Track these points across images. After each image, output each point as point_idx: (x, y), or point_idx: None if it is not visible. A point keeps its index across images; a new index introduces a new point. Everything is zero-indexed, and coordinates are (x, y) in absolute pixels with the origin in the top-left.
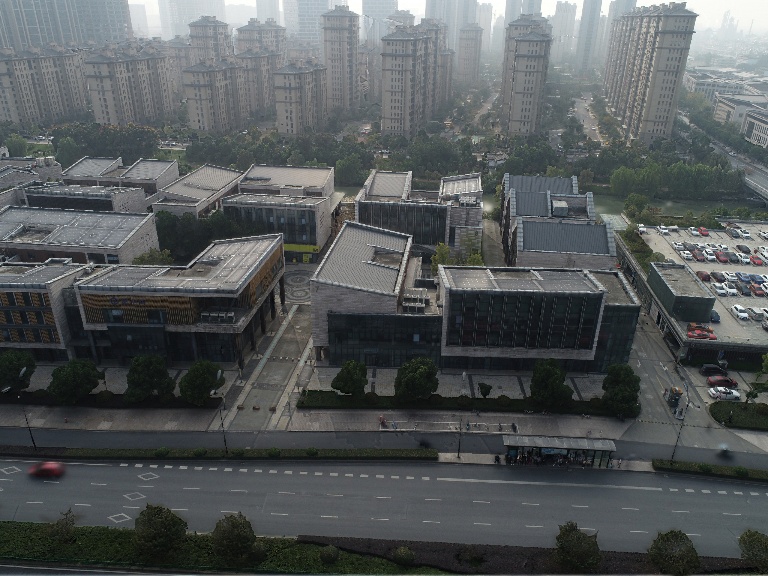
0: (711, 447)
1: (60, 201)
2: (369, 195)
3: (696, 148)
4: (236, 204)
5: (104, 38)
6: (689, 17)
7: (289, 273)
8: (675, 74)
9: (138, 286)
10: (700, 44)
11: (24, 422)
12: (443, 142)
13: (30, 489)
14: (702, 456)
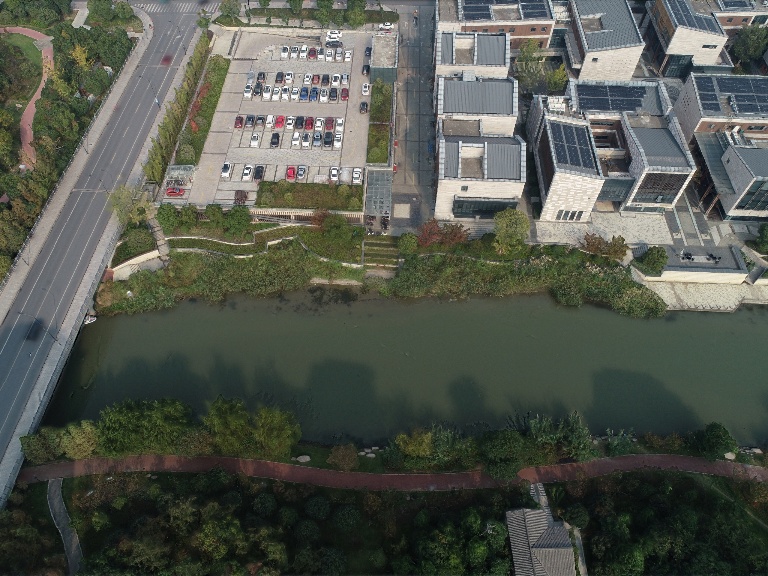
0: (408, 6)
1: None
2: (667, 129)
3: (20, 575)
4: None
5: None
6: None
7: None
8: None
9: None
10: None
11: None
12: None
13: None
14: (414, 2)
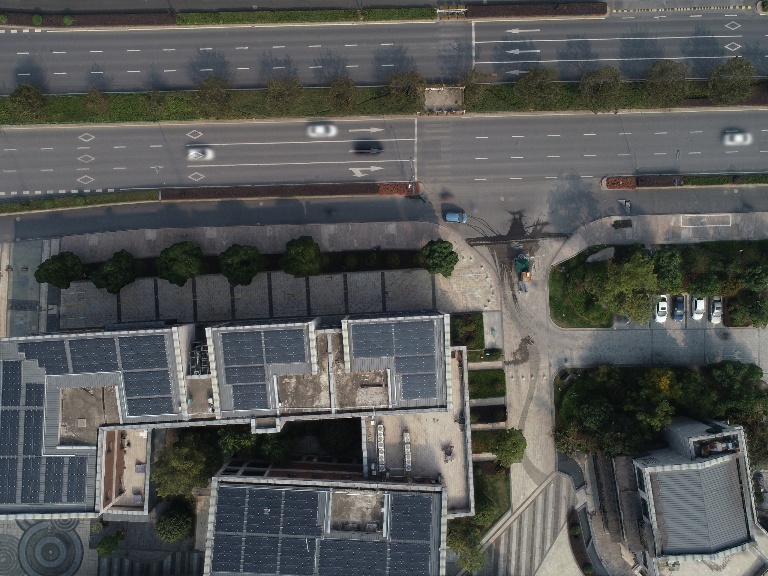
0: None
1: None
2: None
3: None
4: None
5: None
6: None
7: (67, 572)
8: None
9: (108, 337)
10: None
11: (222, 232)
12: None
13: (168, 158)
14: None
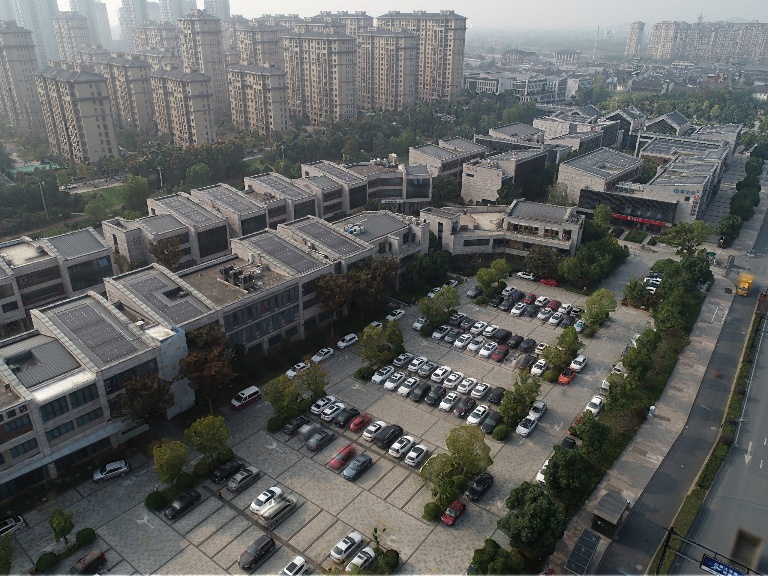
0: None
1: (527, 163)
2: None
3: (500, 96)
4: None
5: None
6: (465, 20)
7: None
8: (462, 55)
9: None
10: (470, 36)
11: (761, 217)
12: None
13: None
14: None
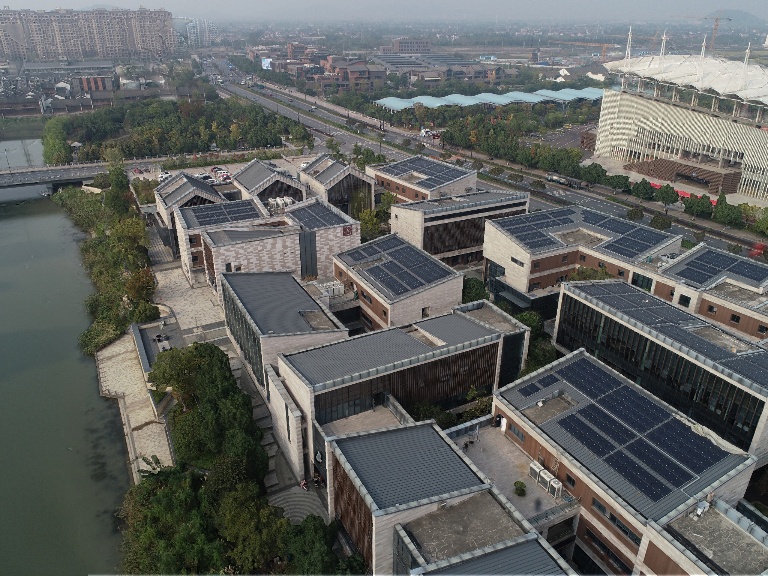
0: None
1: None
2: None
3: None
4: None
5: None
6: None
7: None
8: None
9: (636, 225)
10: None
11: None
12: None
13: None
14: None
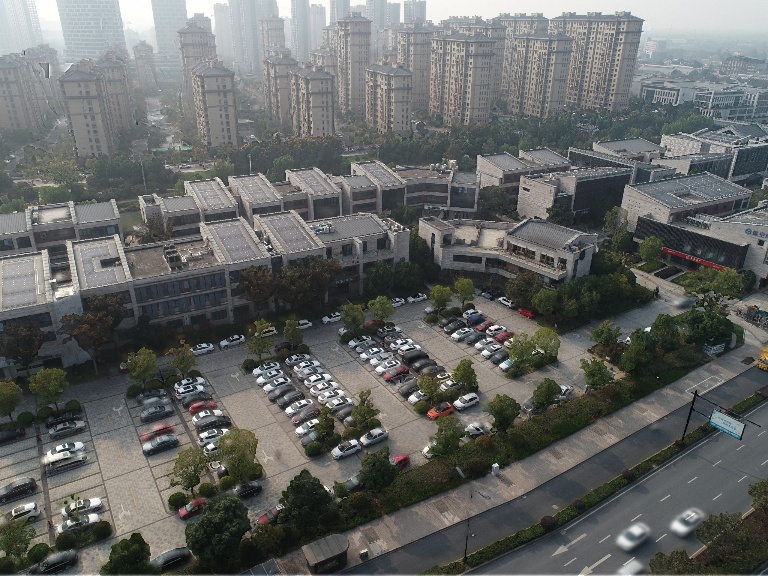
0: None
1: (597, 182)
2: None
3: (670, 108)
4: (697, 162)
5: (23, 50)
6: (641, 22)
7: None
8: (633, 60)
9: None
10: (646, 40)
11: None
12: (563, 120)
13: None
14: None
